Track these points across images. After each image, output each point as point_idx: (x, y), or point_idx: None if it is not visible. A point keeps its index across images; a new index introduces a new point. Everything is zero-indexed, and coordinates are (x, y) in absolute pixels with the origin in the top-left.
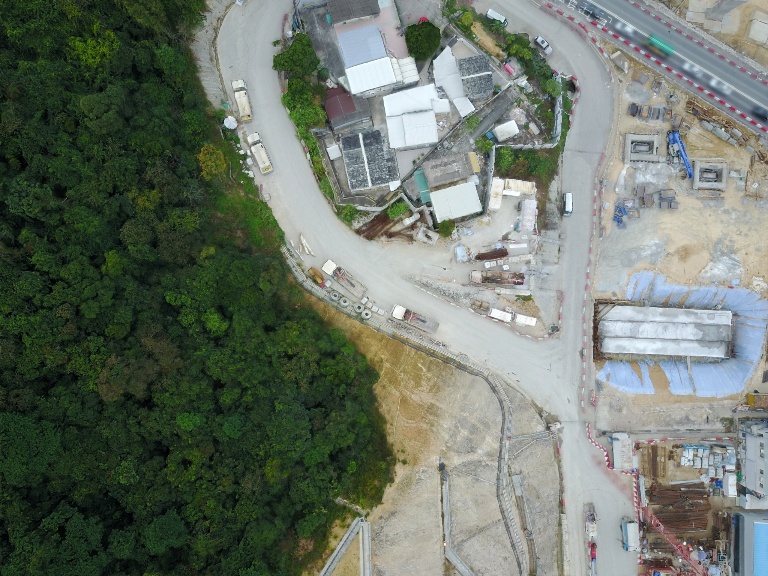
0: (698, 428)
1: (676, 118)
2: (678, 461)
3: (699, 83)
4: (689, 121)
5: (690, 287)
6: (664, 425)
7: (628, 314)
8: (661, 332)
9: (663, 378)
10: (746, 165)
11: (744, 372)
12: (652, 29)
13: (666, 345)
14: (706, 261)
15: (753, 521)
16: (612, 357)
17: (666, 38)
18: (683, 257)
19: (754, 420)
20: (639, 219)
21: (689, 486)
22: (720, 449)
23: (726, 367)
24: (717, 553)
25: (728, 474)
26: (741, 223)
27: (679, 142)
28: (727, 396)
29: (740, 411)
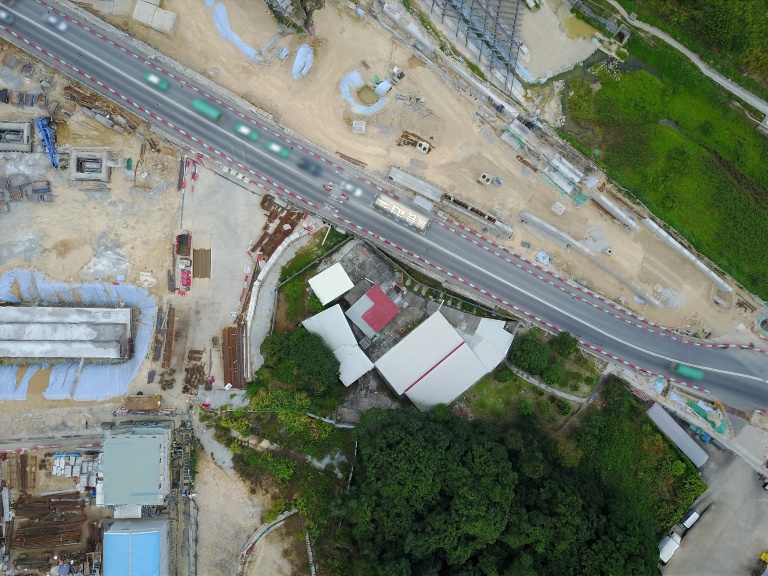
0: (75, 434)
1: (51, 105)
2: (50, 470)
3: (82, 67)
4: (69, 108)
5: (71, 285)
6: (37, 433)
7: (12, 315)
8: (50, 333)
9: (44, 382)
10: (137, 154)
11: (131, 373)
12: (29, 10)
13: (56, 347)
14: (89, 257)
15: (104, 532)
16: (4, 361)
17: (45, 19)
18: (62, 253)
19: (136, 424)
20: (10, 213)
21: (60, 497)
22: (84, 456)
23: (123, 368)
24: (89, 566)
25: (98, 482)
26: (128, 215)
27: (42, 130)
28: (109, 399)
29: (120, 415)
